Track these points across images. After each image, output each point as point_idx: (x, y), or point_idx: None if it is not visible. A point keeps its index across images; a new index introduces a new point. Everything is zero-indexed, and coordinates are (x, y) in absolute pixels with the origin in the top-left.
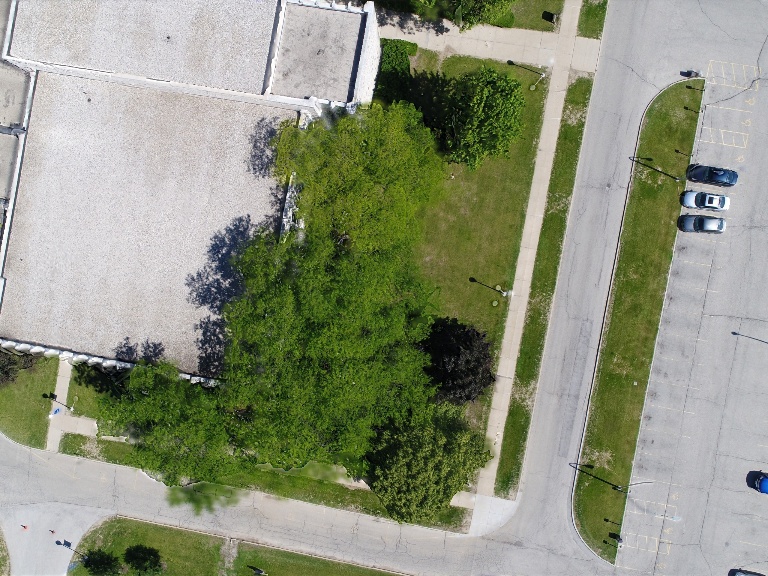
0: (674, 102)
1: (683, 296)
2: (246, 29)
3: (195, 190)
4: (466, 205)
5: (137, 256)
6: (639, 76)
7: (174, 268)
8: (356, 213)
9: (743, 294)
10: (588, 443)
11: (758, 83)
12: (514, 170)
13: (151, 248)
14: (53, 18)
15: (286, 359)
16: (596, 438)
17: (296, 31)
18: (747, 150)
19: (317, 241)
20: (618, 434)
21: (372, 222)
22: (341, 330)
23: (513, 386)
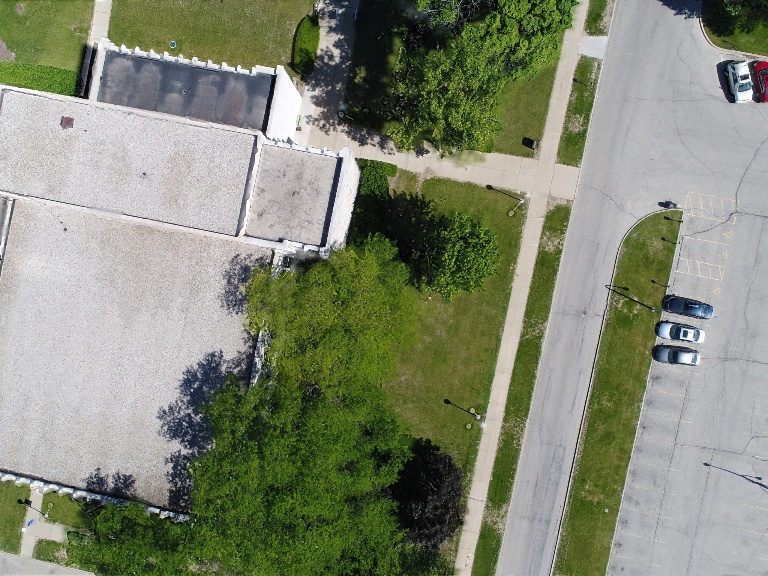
0: (652, 232)
1: (656, 425)
2: (222, 169)
3: (169, 324)
4: (442, 327)
5: (110, 387)
6: (617, 205)
7: (146, 401)
8: (325, 365)
9: (716, 426)
10: (558, 568)
11: (736, 216)
12: (491, 294)
13: (124, 380)
14: (30, 150)
15: (250, 521)
16: (566, 564)
17: (272, 172)
18: (723, 283)
19: (285, 394)
20: (588, 560)
21: (342, 370)
22: (305, 496)
23: (485, 509)
